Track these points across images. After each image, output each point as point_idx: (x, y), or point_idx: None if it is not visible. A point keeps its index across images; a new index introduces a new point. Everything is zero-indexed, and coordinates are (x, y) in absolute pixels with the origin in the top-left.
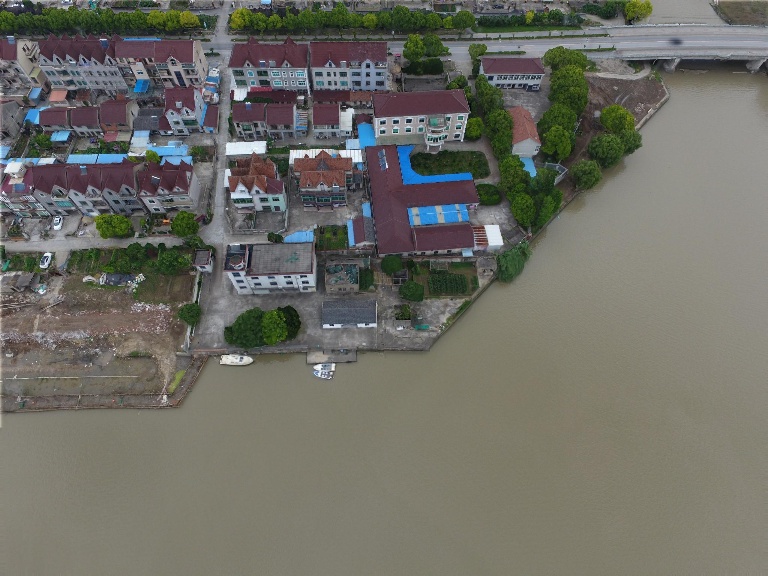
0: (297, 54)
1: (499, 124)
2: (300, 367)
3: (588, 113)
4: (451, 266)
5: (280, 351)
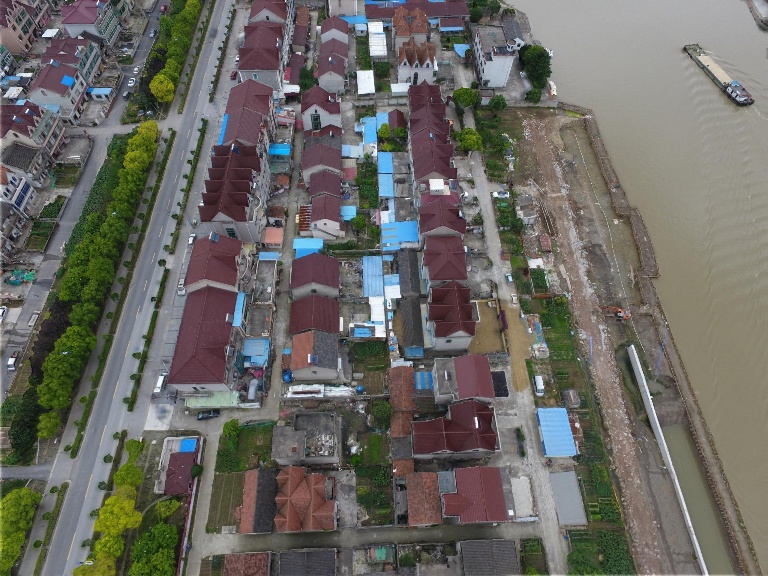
0: (272, 23)
1: None
2: None
3: None
4: None
5: None
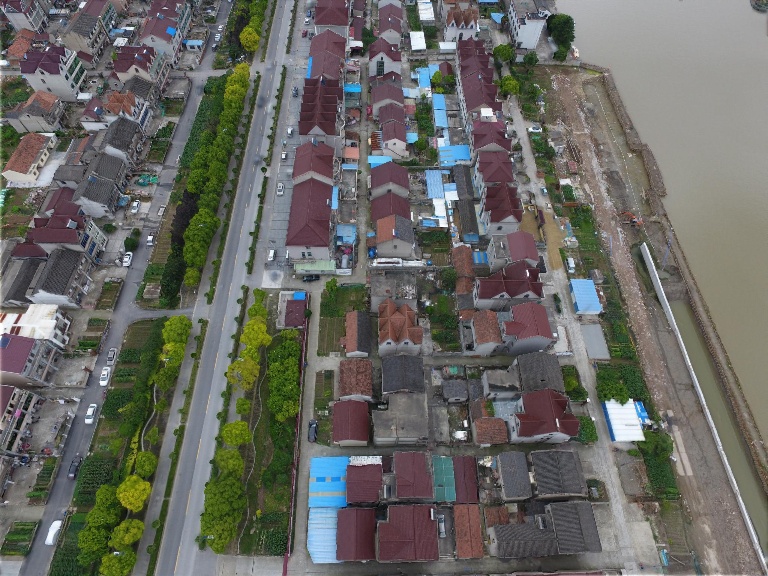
0: None
1: None
2: None
3: None
4: None
5: None
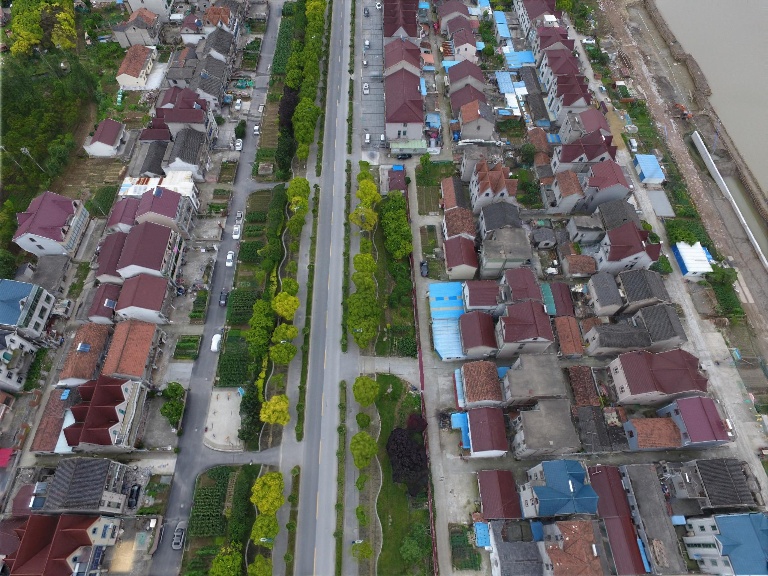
0: None
1: None
2: None
3: None
4: None
5: None
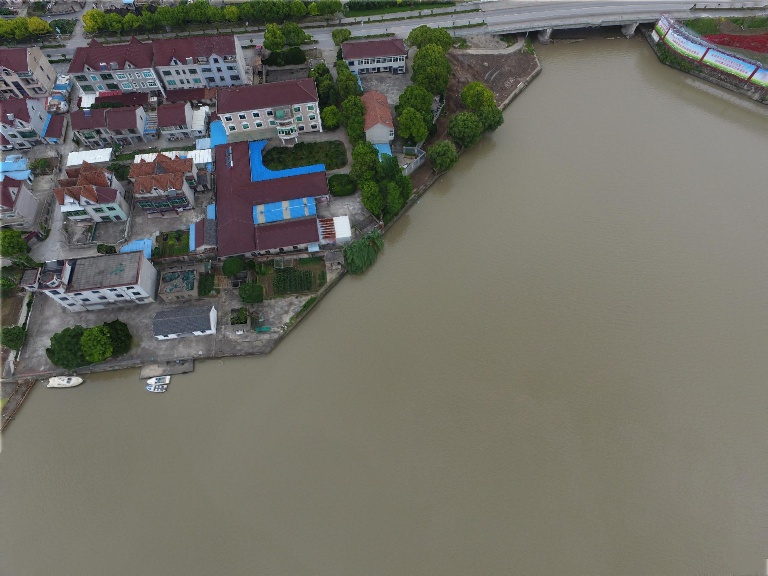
0: (140, 54)
1: (349, 111)
2: (133, 383)
3: (455, 92)
4: (299, 263)
5: (111, 368)
